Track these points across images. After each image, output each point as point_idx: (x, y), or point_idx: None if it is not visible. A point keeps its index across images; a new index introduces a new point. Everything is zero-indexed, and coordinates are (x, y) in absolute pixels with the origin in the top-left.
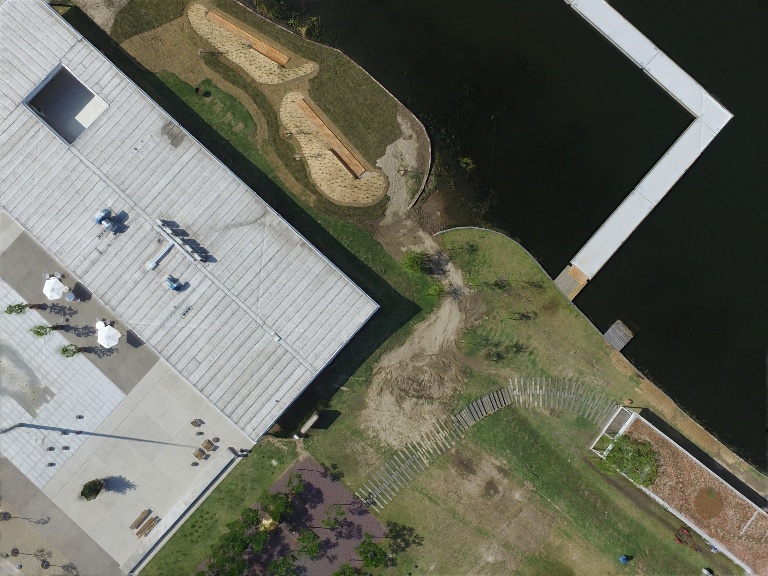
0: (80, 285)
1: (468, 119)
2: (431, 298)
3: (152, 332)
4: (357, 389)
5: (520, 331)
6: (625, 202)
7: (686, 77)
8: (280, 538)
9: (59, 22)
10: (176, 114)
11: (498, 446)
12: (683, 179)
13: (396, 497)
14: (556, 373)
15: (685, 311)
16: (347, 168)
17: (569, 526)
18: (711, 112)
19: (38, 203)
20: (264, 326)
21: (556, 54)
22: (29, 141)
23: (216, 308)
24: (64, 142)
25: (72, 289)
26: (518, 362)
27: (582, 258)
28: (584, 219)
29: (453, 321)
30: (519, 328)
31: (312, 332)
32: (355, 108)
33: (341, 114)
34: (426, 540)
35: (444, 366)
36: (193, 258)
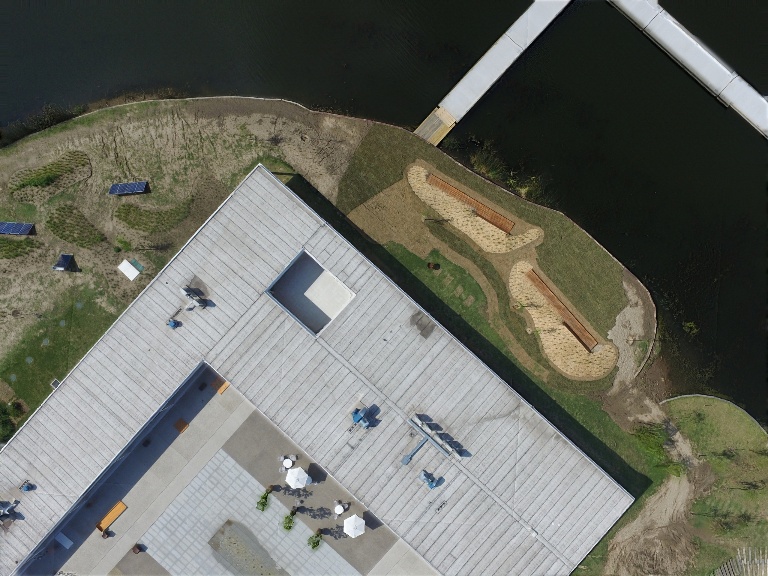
0: (314, 466)
1: (691, 282)
2: None
3: (407, 528)
4: (594, 567)
5: (748, 501)
6: None
7: None
8: None
9: (300, 206)
10: (407, 289)
11: None
12: None
13: None
14: None
15: None
16: (582, 343)
17: None
18: None
19: (286, 396)
20: (520, 521)
21: None
22: (275, 332)
23: (471, 503)
24: (311, 333)
25: (307, 471)
26: (746, 532)
27: None
28: None
29: (682, 492)
30: (747, 498)
31: (568, 526)
32: (583, 276)
33: (570, 284)
34: None
35: (674, 538)
36: (448, 453)
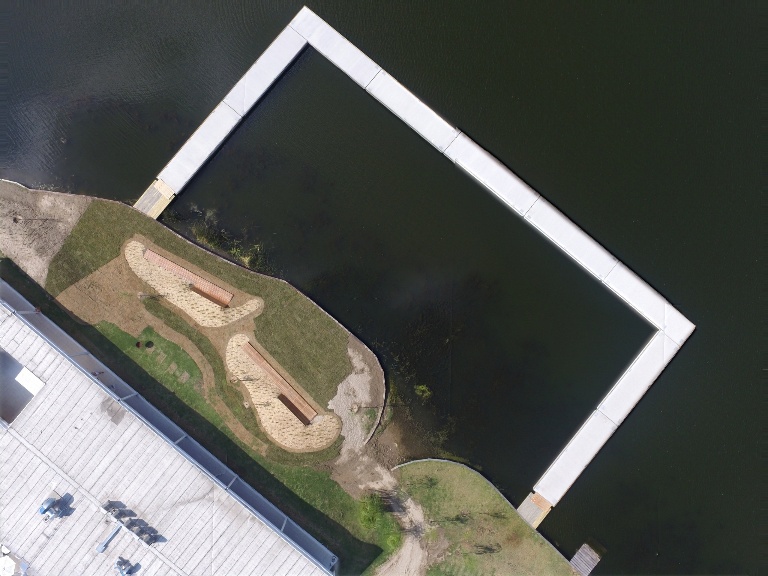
0: None
1: (422, 344)
2: None
3: None
4: None
5: (484, 565)
6: (587, 424)
7: (647, 287)
8: None
9: None
10: (118, 369)
11: None
12: (647, 394)
13: None
14: None
15: (653, 529)
16: (298, 416)
17: None
18: (674, 323)
19: None
20: None
21: (511, 270)
22: None
23: None
24: (2, 424)
25: None
26: None
27: (545, 485)
28: (546, 441)
29: (415, 559)
30: (483, 562)
31: None
32: (304, 345)
33: (289, 354)
34: None
35: None
36: (142, 539)
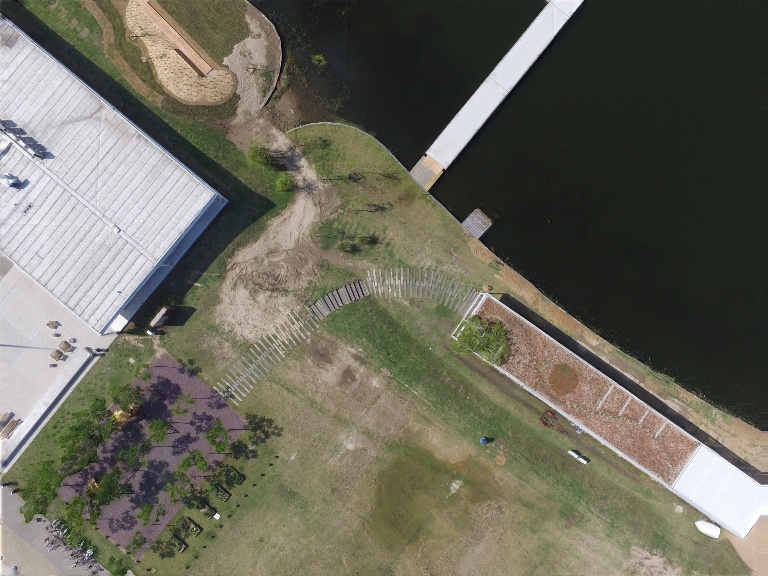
0: None
1: (319, 16)
2: (285, 194)
3: None
4: (211, 285)
5: (376, 223)
6: (478, 90)
7: None
8: (141, 435)
9: None
10: (20, 22)
11: (353, 334)
12: (538, 65)
13: (254, 389)
14: (414, 263)
15: (545, 197)
16: (192, 66)
17: (428, 410)
18: None
19: None
20: (103, 219)
21: None
22: None
23: (56, 204)
24: None
25: None
26: (375, 254)
27: (437, 148)
28: (439, 110)
29: (308, 216)
30: (375, 220)
31: (151, 222)
32: (202, 9)
33: (187, 15)
34: (285, 430)
35: (300, 260)
36: (30, 155)
